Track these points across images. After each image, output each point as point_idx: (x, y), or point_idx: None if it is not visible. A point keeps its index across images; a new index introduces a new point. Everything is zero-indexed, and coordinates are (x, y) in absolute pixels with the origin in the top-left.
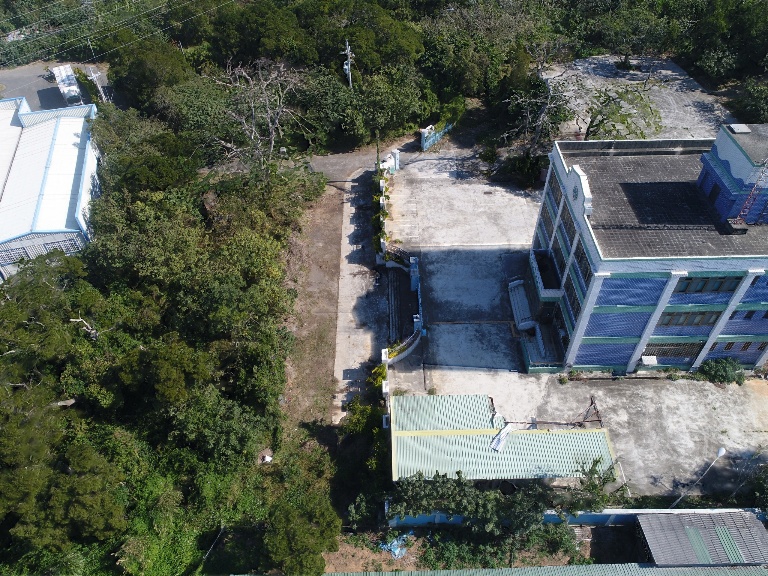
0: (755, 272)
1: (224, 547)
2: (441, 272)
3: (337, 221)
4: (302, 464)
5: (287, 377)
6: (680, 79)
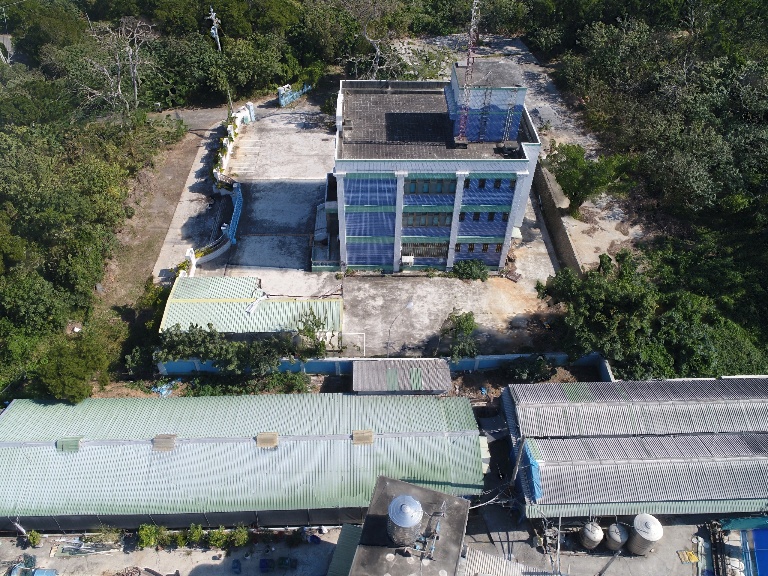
0: (461, 174)
1: (23, 389)
2: (264, 198)
3: (189, 160)
4: (104, 333)
5: (110, 273)
6: (521, 54)
